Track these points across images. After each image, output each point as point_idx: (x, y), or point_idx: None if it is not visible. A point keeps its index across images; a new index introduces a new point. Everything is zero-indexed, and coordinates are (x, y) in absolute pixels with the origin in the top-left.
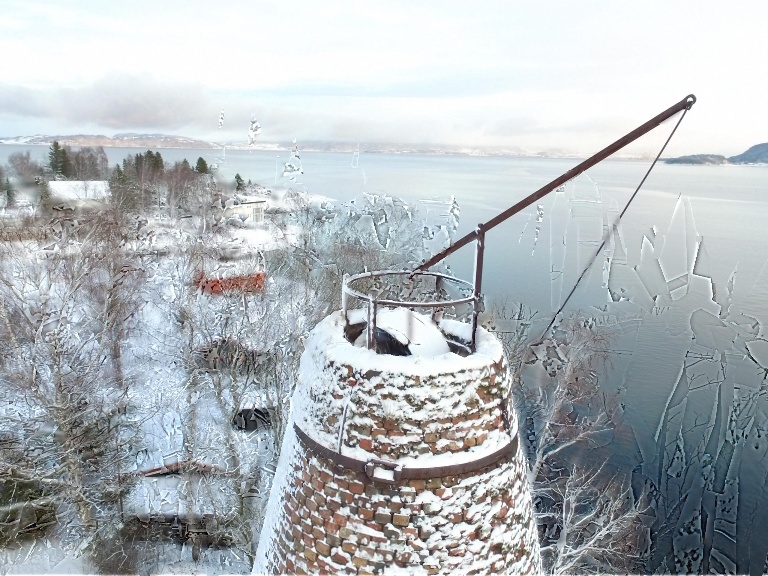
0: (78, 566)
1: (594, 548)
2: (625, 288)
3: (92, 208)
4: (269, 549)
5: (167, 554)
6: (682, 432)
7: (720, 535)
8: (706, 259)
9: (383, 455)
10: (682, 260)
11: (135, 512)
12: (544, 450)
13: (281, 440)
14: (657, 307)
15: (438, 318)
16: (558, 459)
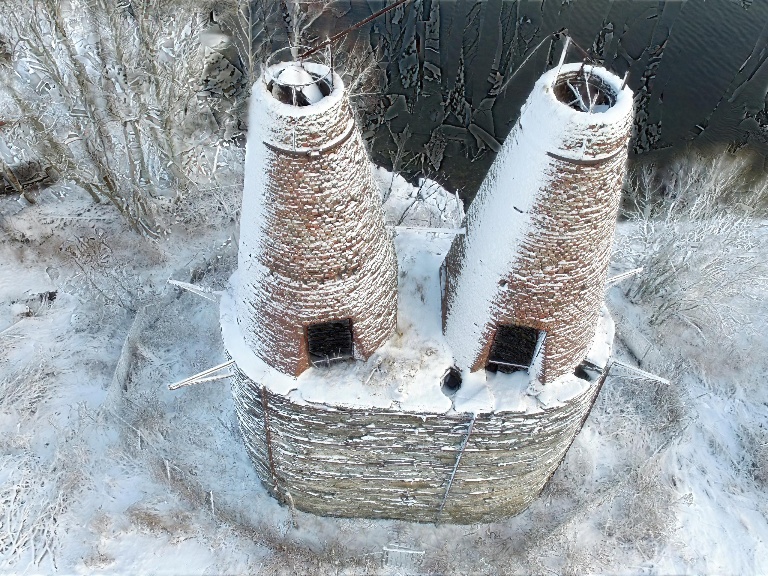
0: None
1: (352, 96)
2: None
3: None
4: (265, 192)
5: (7, 208)
6: None
7: (429, 51)
8: None
9: (313, 147)
10: None
11: None
12: (299, 27)
13: (62, 81)
14: None
15: (302, 63)
16: (312, 32)
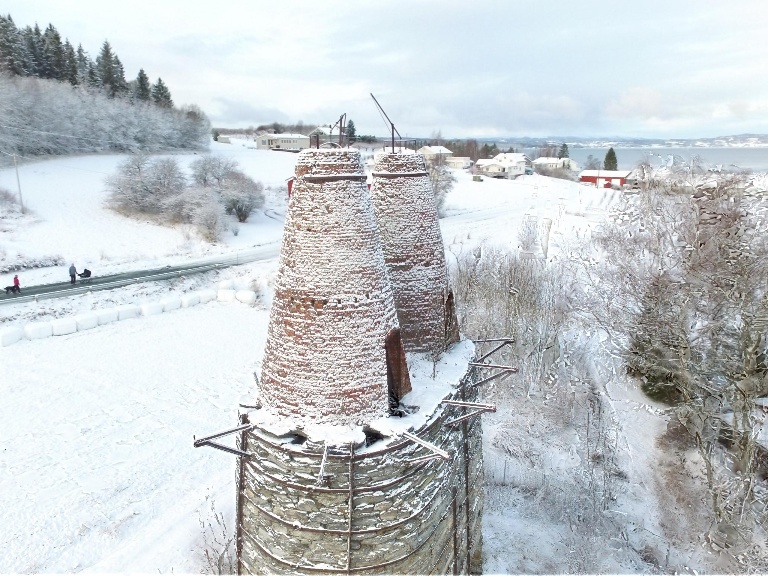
0: None
1: None
2: None
3: (727, 170)
4: None
5: None
6: None
7: None
8: None
9: None
10: None
11: (657, 374)
12: None
13: None
14: None
15: None
16: None
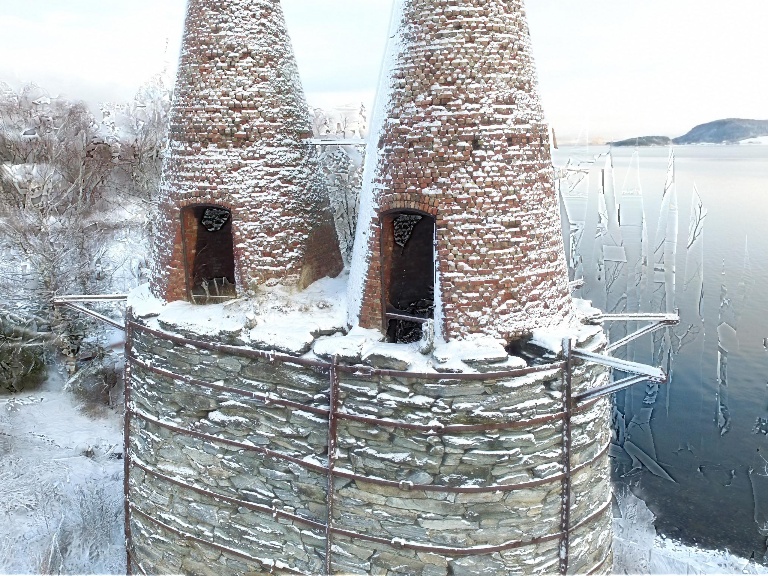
0: (67, 402)
1: None
2: None
3: (65, 101)
4: None
5: None
6: None
7: None
8: None
9: None
10: None
11: None
12: None
13: None
14: None
15: None
16: None
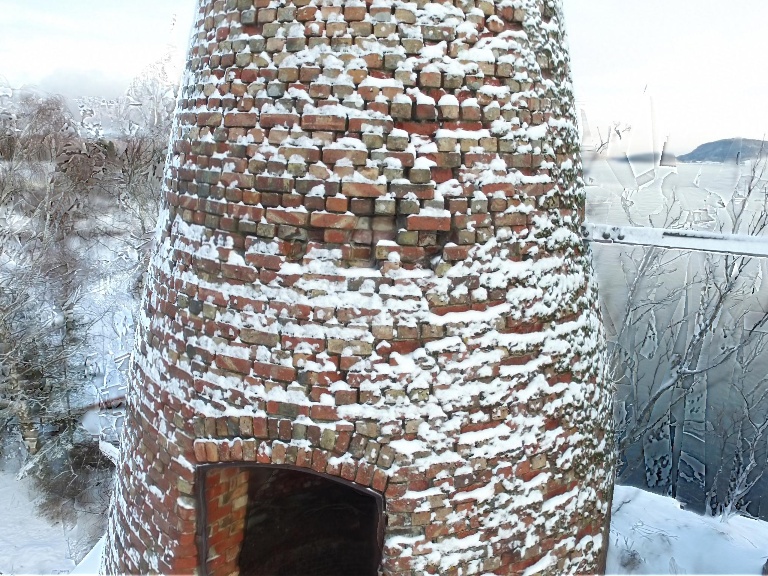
0: (23, 492)
1: None
2: (594, 177)
3: (31, 94)
4: None
5: None
6: (654, 310)
7: (689, 437)
8: (673, 148)
9: None
10: (649, 155)
11: (83, 410)
12: None
13: None
14: (626, 191)
15: None
16: None
